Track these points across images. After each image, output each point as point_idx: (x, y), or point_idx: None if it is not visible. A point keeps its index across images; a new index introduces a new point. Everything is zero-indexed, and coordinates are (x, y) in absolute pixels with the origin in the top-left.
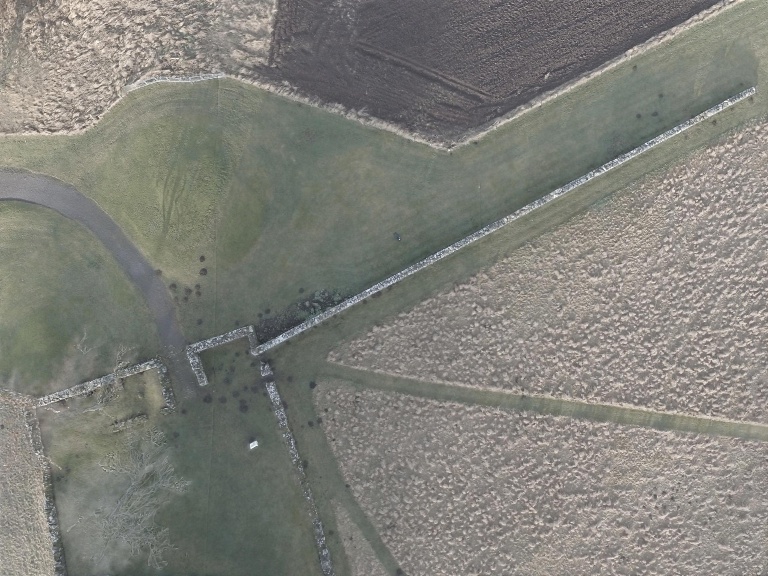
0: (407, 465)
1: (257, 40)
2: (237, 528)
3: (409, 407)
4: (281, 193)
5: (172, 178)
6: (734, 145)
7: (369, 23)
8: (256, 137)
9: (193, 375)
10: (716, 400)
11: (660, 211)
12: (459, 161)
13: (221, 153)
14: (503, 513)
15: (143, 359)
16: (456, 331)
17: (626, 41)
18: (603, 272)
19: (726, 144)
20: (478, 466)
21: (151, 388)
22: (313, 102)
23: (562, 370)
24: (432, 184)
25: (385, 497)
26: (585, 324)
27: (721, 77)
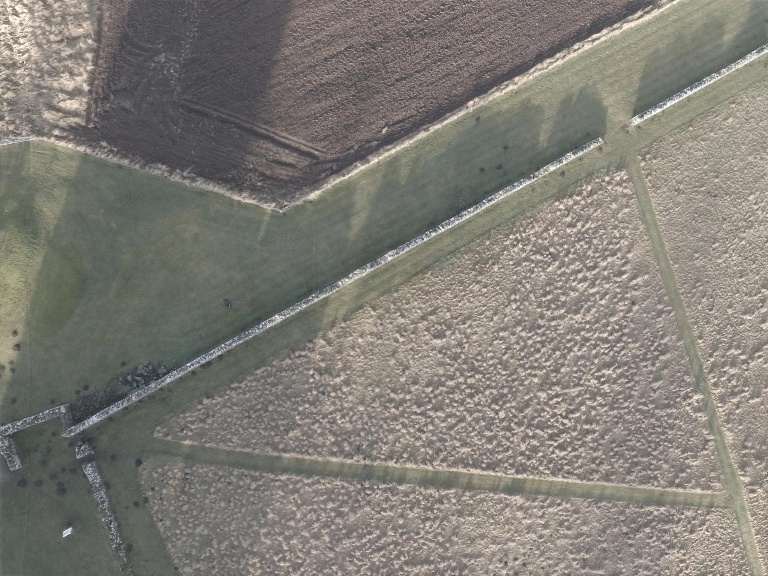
0: (241, 543)
1: (71, 100)
2: None
3: (243, 482)
4: (100, 261)
5: None
6: (583, 197)
7: (195, 78)
8: (72, 203)
9: None
10: (567, 461)
11: (507, 267)
12: (293, 221)
13: (32, 221)
14: None
15: None
16: (293, 400)
17: (468, 92)
18: (447, 333)
19: (574, 196)
20: (317, 541)
21: None
22: (134, 164)
23: (406, 436)
24: (264, 246)
25: None
26: (429, 388)
27: (567, 127)
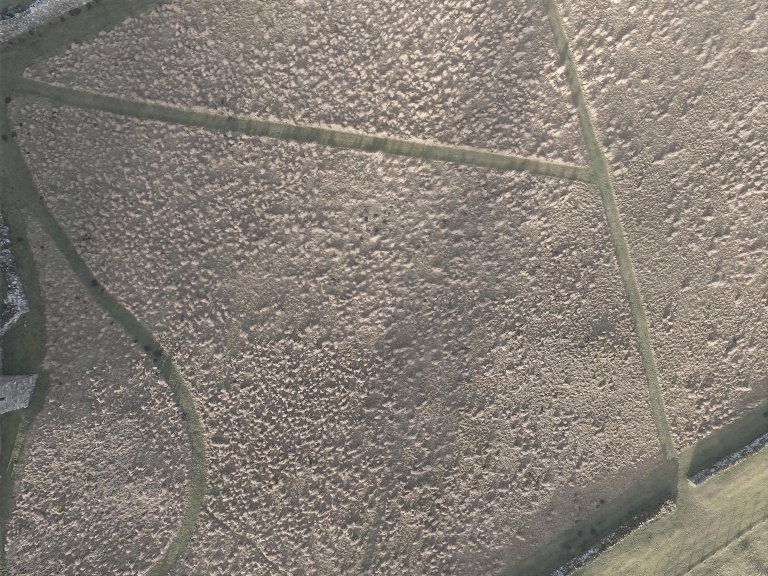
0: (105, 180)
1: None
2: None
3: (108, 124)
4: None
5: None
6: None
7: None
8: None
9: None
10: (428, 123)
11: None
12: None
13: None
14: (206, 230)
15: None
16: (159, 51)
17: None
18: None
19: None
20: (180, 183)
21: None
22: None
23: (269, 92)
24: None
25: (81, 210)
26: (292, 46)
27: None
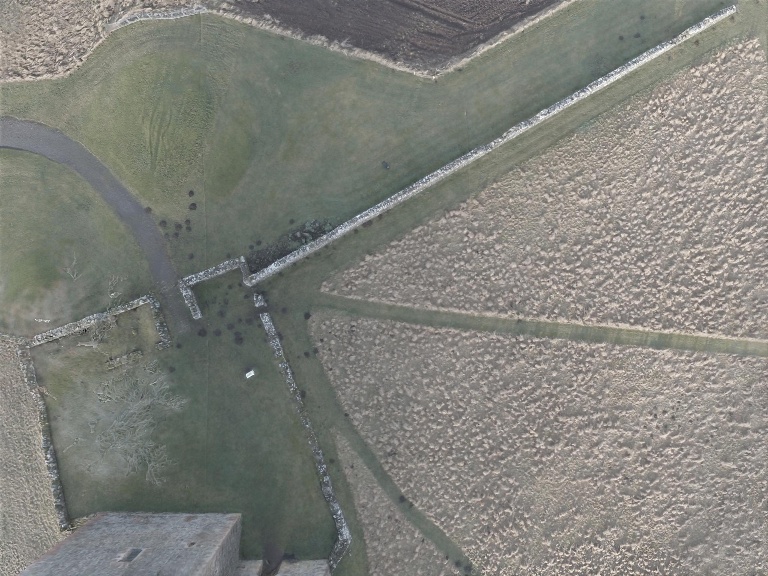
0: (405, 392)
1: None
2: (237, 458)
3: (405, 335)
4: (268, 126)
5: (158, 113)
6: (717, 64)
7: None
8: (240, 71)
9: (186, 309)
10: (712, 317)
11: (647, 132)
12: (444, 89)
13: (206, 87)
14: (504, 437)
15: (136, 296)
16: (449, 258)
17: None
18: (593, 194)
19: (709, 63)
20: (477, 391)
21: (145, 324)
22: (296, 35)
23: (557, 293)
24: (418, 112)
25: (385, 425)
26: (577, 246)
27: None
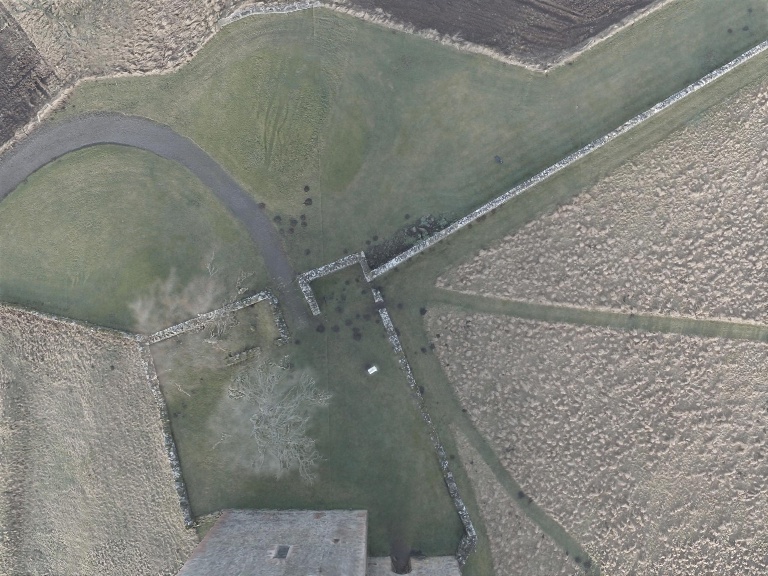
0: (522, 388)
1: None
2: (360, 455)
3: (520, 330)
4: (381, 120)
5: (274, 108)
6: None
7: None
8: (354, 65)
9: (304, 305)
10: None
11: (756, 125)
12: (555, 82)
13: (321, 82)
14: (619, 432)
15: (252, 292)
16: (562, 252)
17: None
18: (704, 187)
19: None
20: (592, 386)
21: (263, 320)
22: (408, 28)
23: (669, 287)
24: (530, 106)
25: (502, 420)
26: (689, 240)
27: None
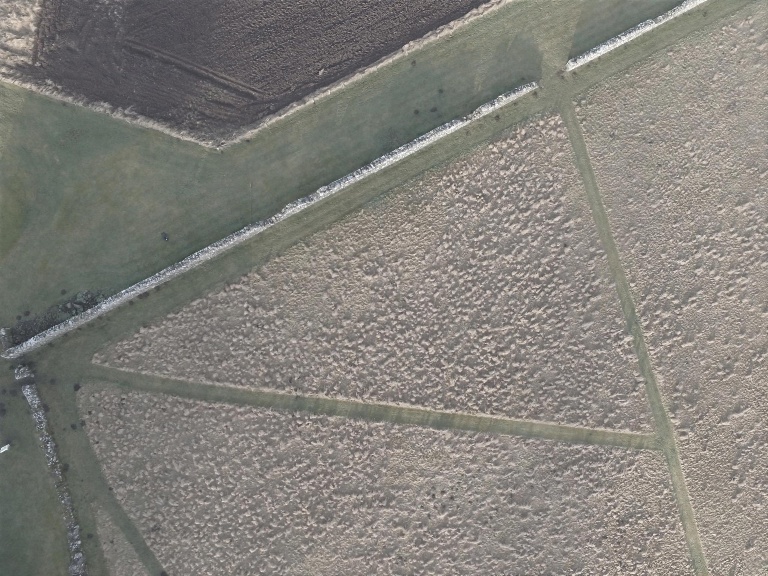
0: (174, 467)
1: (18, 38)
2: None
3: (177, 409)
4: (43, 193)
5: None
6: (517, 140)
7: (137, 20)
8: (17, 137)
9: None
10: (496, 398)
11: (440, 208)
12: (230, 159)
13: None
14: (274, 514)
15: None
16: (227, 331)
17: (404, 36)
18: (379, 270)
19: (508, 139)
20: (248, 467)
21: None
22: (77, 101)
23: (337, 370)
24: (202, 183)
25: (150, 500)
26: (360, 323)
27: (502, 72)
